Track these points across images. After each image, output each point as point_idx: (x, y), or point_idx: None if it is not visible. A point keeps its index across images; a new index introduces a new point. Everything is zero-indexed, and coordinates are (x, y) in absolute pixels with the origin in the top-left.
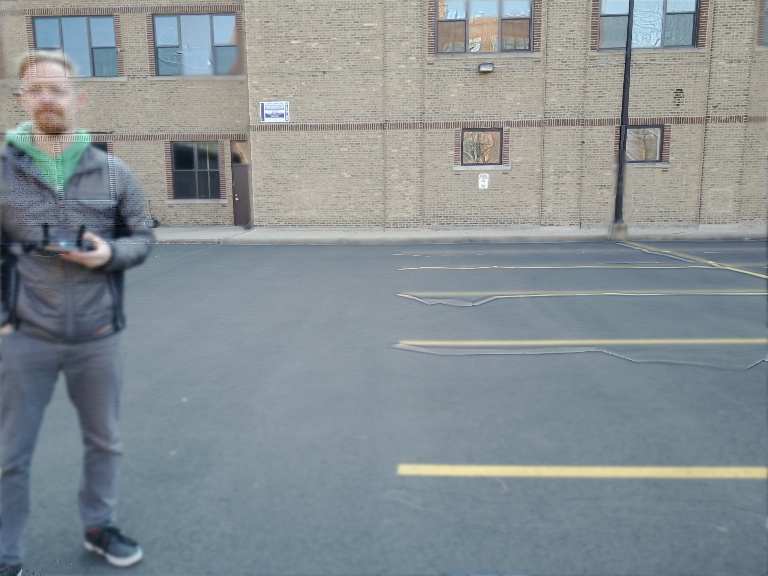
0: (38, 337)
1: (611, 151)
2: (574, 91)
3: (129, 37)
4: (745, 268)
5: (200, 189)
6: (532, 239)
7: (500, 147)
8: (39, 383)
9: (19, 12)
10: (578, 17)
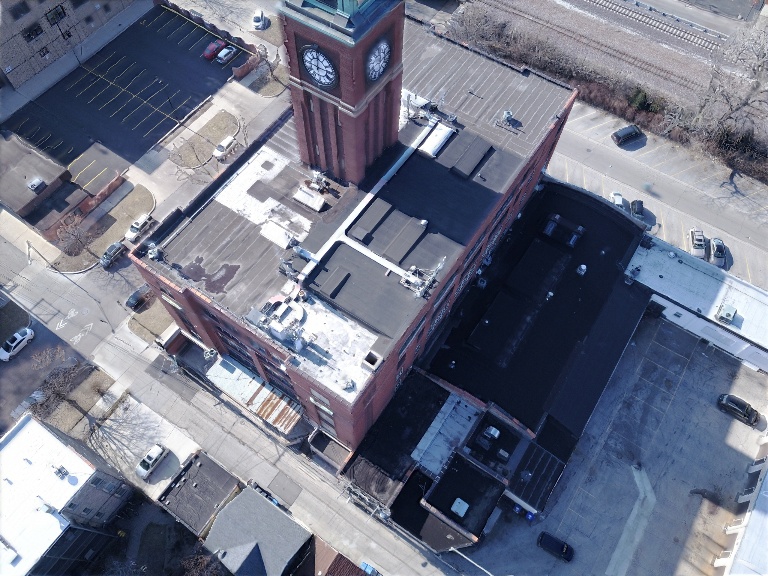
0: None
1: None
2: None
3: None
4: (104, 77)
5: None
6: (70, 71)
7: None
8: None
9: None
10: None
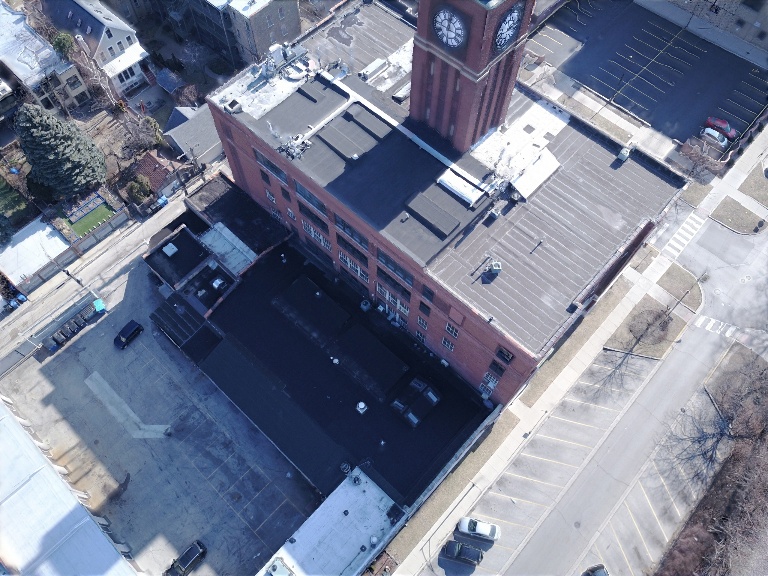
0: (608, 33)
1: None
2: None
3: None
4: None
5: None
6: (675, 22)
7: None
8: (608, 39)
9: None
10: None
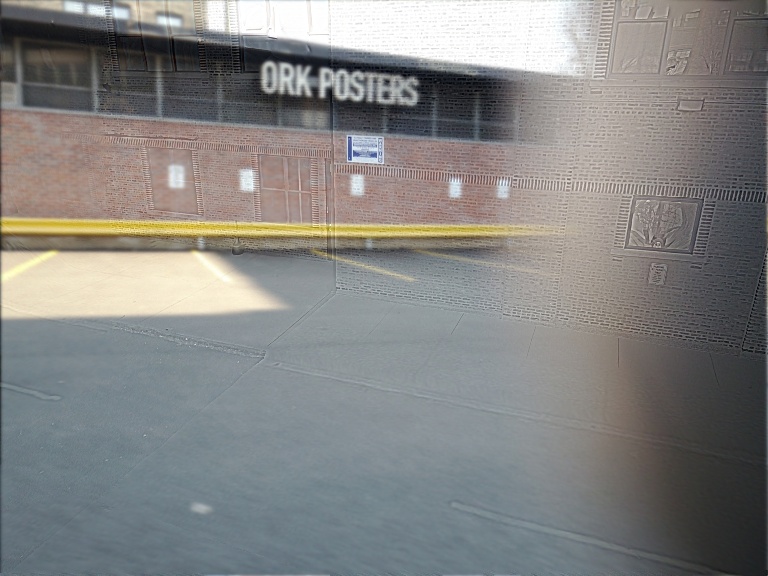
0: None
1: None
2: None
3: (210, 23)
4: None
5: (291, 212)
6: (710, 440)
7: (694, 229)
8: None
9: None
10: None
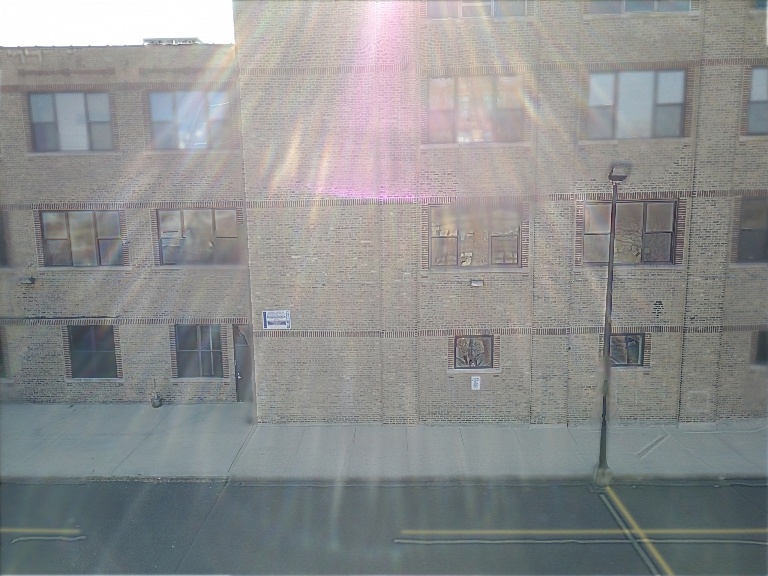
0: None
1: (596, 356)
2: (560, 303)
3: (134, 230)
4: None
5: (203, 367)
6: (522, 478)
7: (491, 353)
8: None
9: (27, 207)
10: (563, 238)
